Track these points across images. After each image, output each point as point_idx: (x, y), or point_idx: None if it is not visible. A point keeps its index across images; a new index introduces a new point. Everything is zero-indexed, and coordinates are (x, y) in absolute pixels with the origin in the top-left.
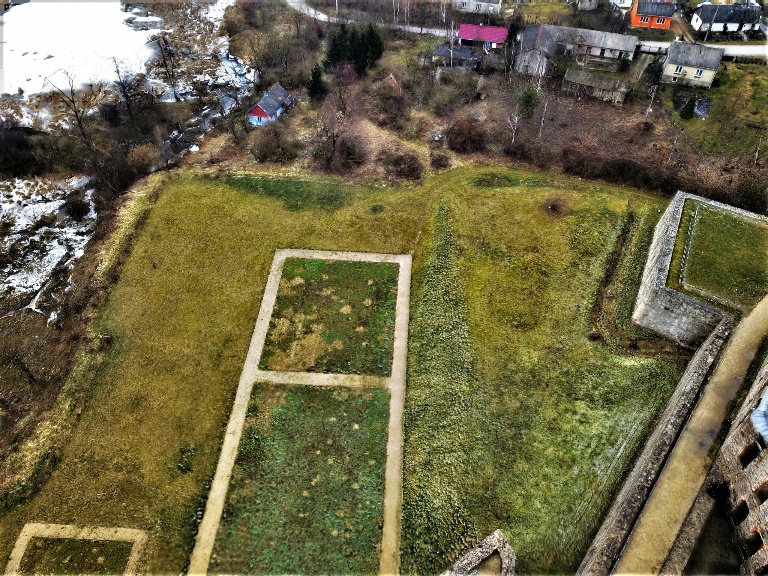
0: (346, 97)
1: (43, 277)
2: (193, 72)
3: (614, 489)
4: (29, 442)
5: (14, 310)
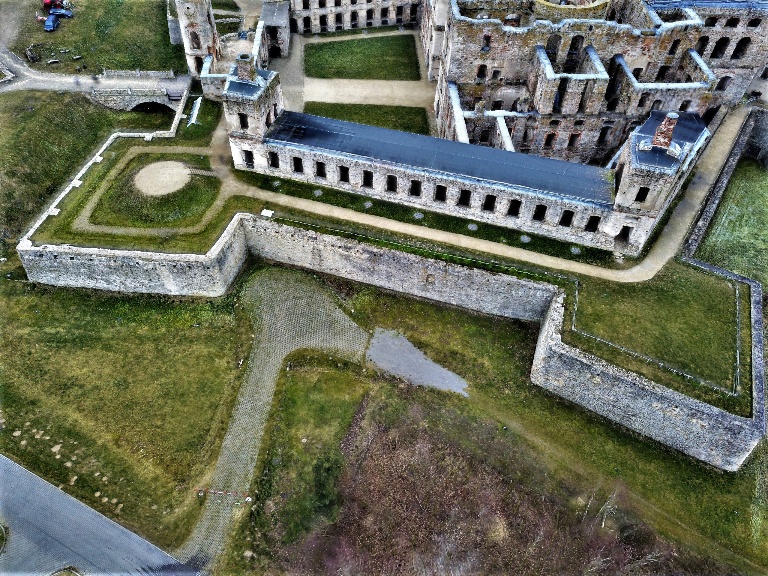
0: None
1: None
2: None
3: (723, 199)
4: None
5: None
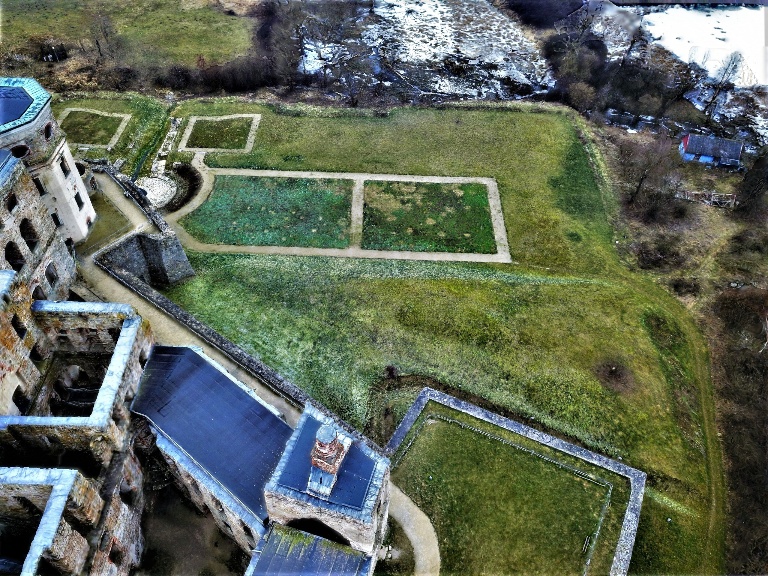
0: (757, 195)
1: (450, 91)
2: (763, 113)
3: None
4: (311, 106)
5: (418, 88)
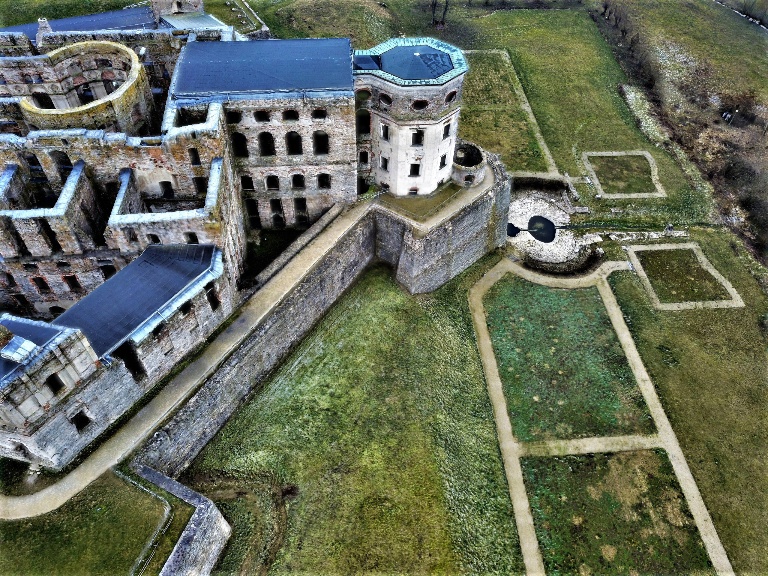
0: None
1: None
2: None
3: (311, 332)
4: None
5: None
